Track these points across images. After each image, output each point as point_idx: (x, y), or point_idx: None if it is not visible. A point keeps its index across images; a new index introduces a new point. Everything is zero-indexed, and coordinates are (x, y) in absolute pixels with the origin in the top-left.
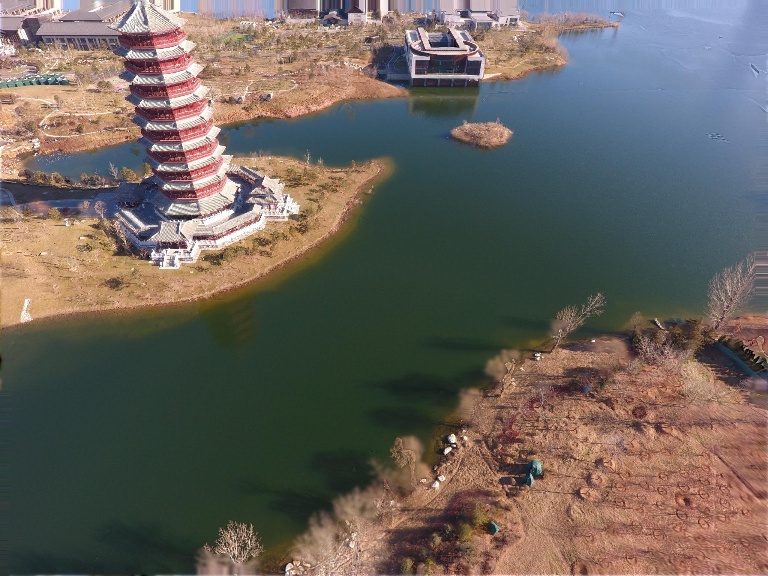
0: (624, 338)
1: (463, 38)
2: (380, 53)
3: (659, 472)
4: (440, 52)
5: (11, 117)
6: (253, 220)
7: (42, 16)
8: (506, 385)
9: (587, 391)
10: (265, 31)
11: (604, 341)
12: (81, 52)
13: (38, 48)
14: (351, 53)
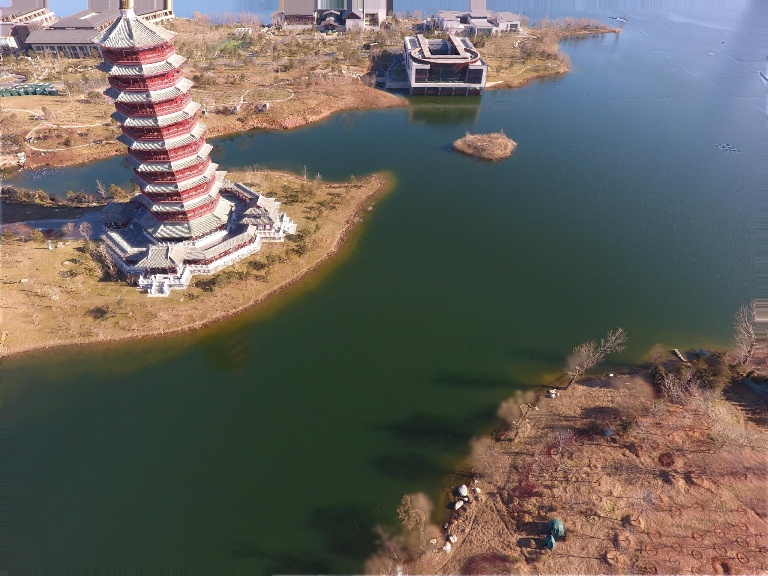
0: (644, 372)
1: (464, 45)
2: (379, 60)
3: (692, 531)
4: (441, 60)
5: None
6: (247, 242)
7: (32, 23)
8: (521, 429)
9: (608, 435)
10: (261, 38)
11: (623, 375)
12: (72, 60)
13: (27, 56)
14: (349, 61)
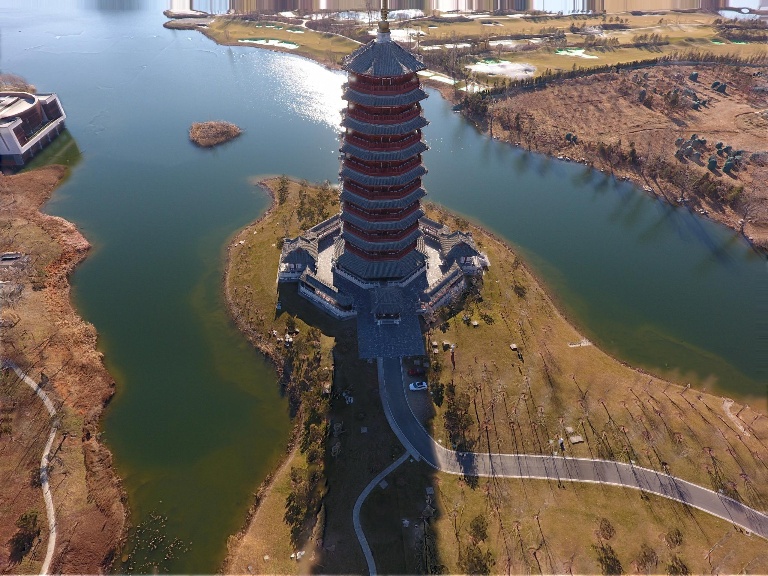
0: (472, 119)
1: None
2: None
3: None
4: (3, 112)
5: None
6: None
7: None
8: None
9: None
10: None
11: (476, 123)
12: None
13: None
14: None
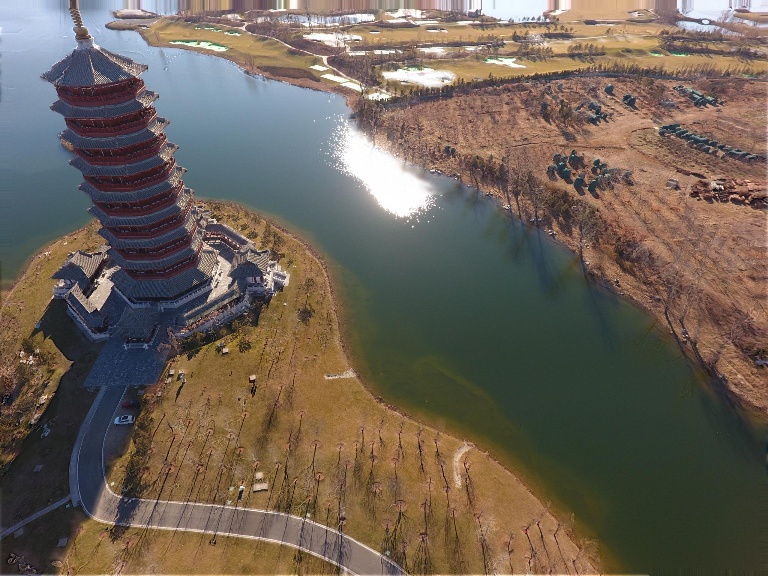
0: (363, 128)
1: None
2: None
3: None
4: None
5: None
6: None
7: None
8: None
9: None
10: None
11: None
12: None
13: None
14: None
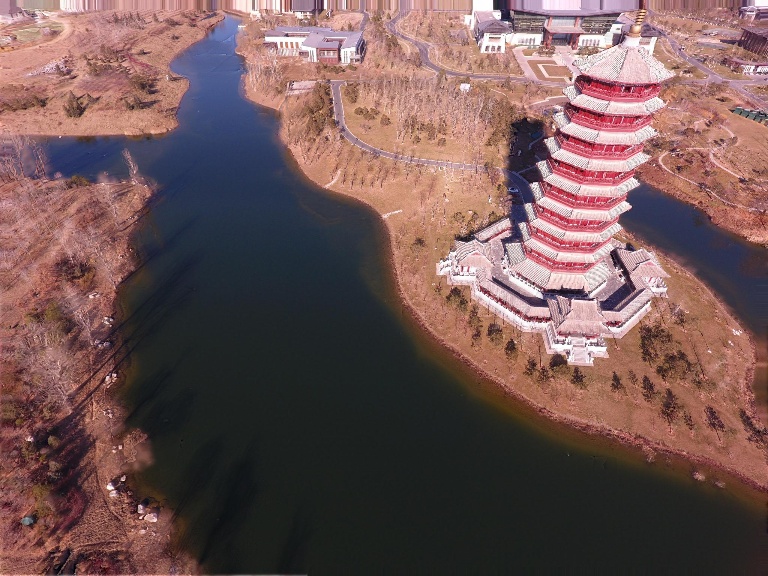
0: None
1: None
2: None
3: None
4: None
5: (681, 134)
6: None
7: None
8: None
9: None
10: None
11: None
12: None
13: None
14: None
